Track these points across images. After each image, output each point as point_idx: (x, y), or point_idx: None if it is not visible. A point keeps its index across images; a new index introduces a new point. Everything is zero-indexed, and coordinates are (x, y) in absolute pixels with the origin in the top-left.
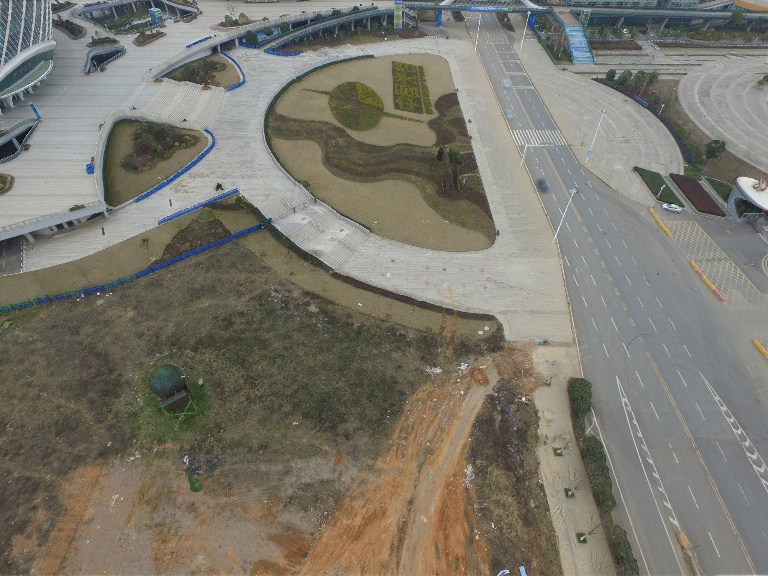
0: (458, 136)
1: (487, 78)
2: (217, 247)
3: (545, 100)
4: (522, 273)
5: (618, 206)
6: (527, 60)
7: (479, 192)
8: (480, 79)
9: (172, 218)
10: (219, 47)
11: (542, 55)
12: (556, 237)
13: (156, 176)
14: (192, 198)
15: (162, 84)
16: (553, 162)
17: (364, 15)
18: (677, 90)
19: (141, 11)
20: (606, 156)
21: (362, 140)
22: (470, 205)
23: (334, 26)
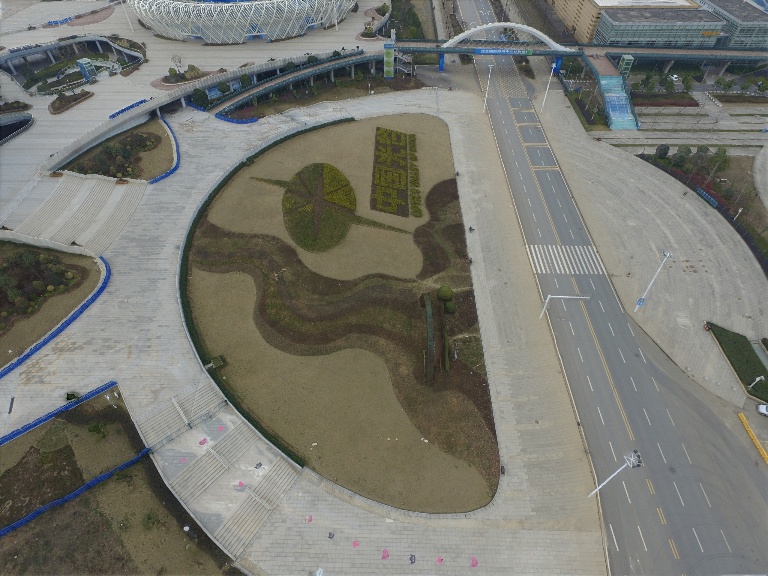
0: (453, 258)
1: (498, 152)
2: (52, 512)
3: (574, 191)
4: (540, 571)
5: (689, 405)
6: (550, 123)
7: (477, 373)
8: (488, 154)
9: (1, 442)
10: (158, 111)
11: (570, 115)
12: (595, 477)
13: (6, 349)
14: (45, 396)
15: (59, 180)
16: (587, 309)
17: (346, 63)
18: (753, 174)
19: (81, 55)
20: (664, 298)
21: (317, 270)
22: (462, 402)
23: (308, 77)
